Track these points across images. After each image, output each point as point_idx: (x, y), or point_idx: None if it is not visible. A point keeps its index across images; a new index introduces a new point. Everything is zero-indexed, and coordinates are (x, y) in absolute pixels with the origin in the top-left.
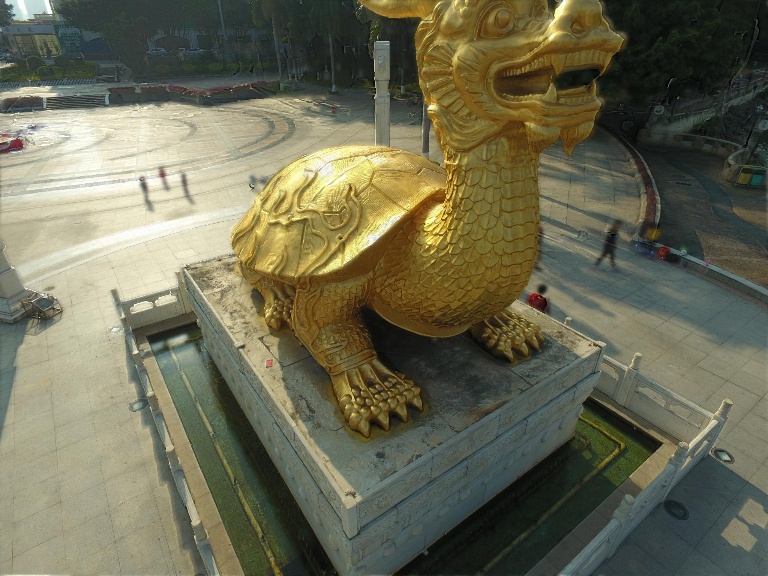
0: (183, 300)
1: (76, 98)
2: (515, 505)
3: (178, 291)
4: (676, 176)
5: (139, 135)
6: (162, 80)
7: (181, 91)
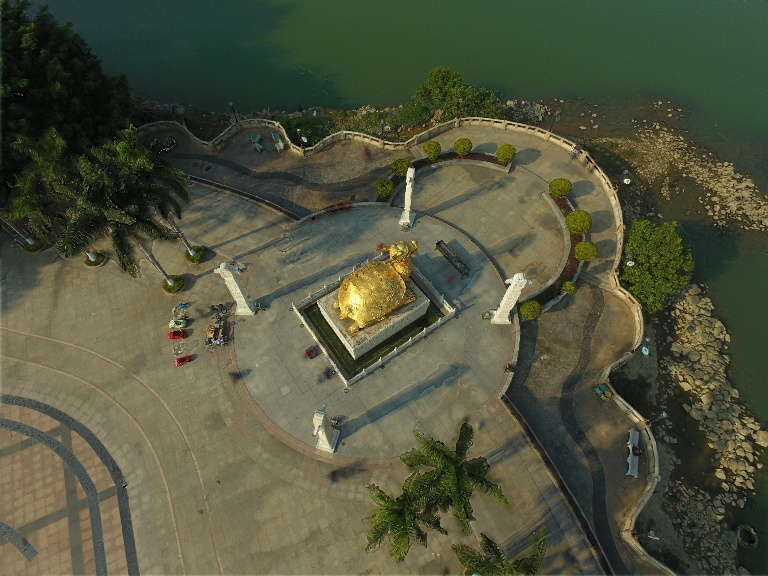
0: None
1: None
2: None
3: None
4: (195, 166)
5: None
6: None
7: None
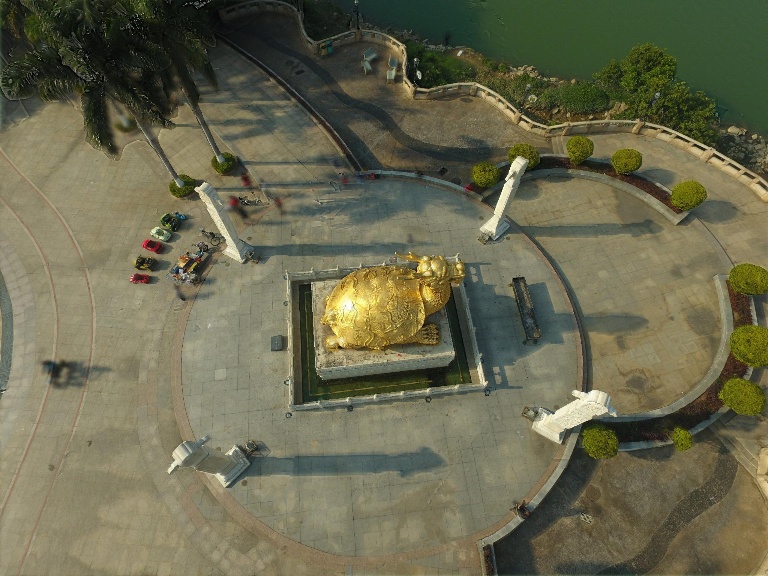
0: (292, 381)
1: None
2: None
3: (291, 381)
4: (288, 64)
5: None
6: None
7: None
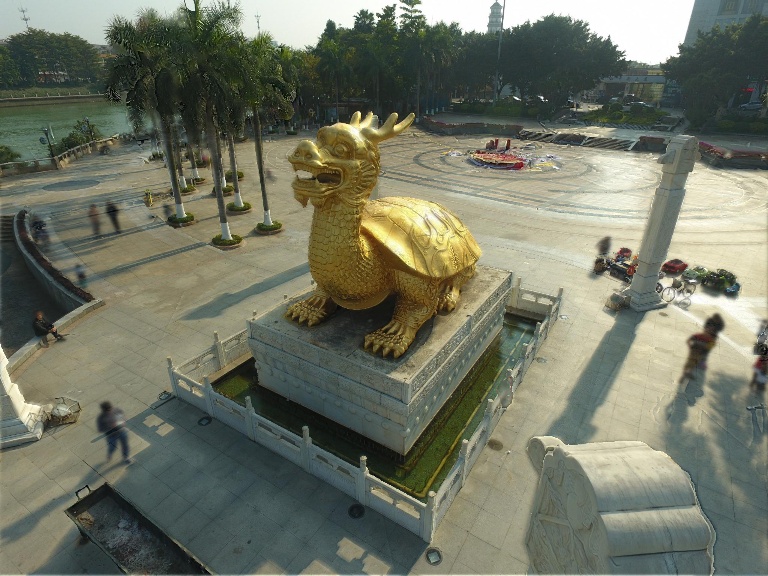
0: None
1: (610, 140)
2: (333, 434)
3: None
4: None
5: (602, 179)
6: (714, 135)
7: (705, 149)
